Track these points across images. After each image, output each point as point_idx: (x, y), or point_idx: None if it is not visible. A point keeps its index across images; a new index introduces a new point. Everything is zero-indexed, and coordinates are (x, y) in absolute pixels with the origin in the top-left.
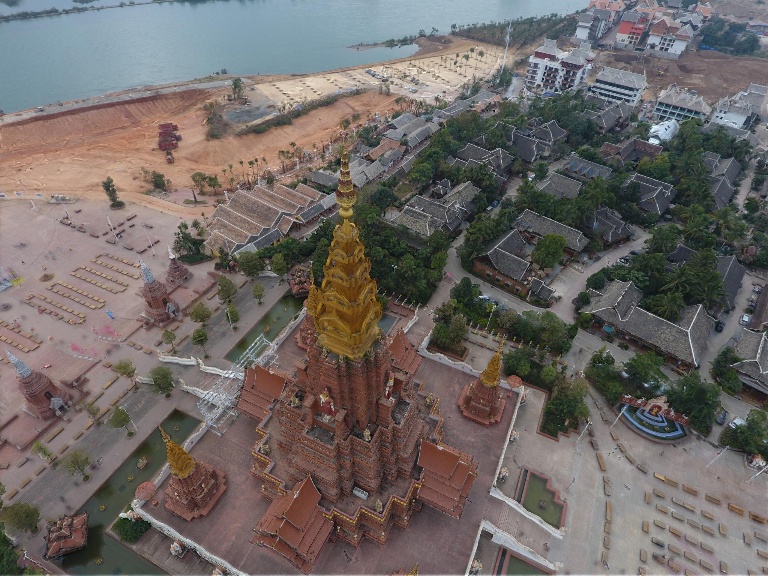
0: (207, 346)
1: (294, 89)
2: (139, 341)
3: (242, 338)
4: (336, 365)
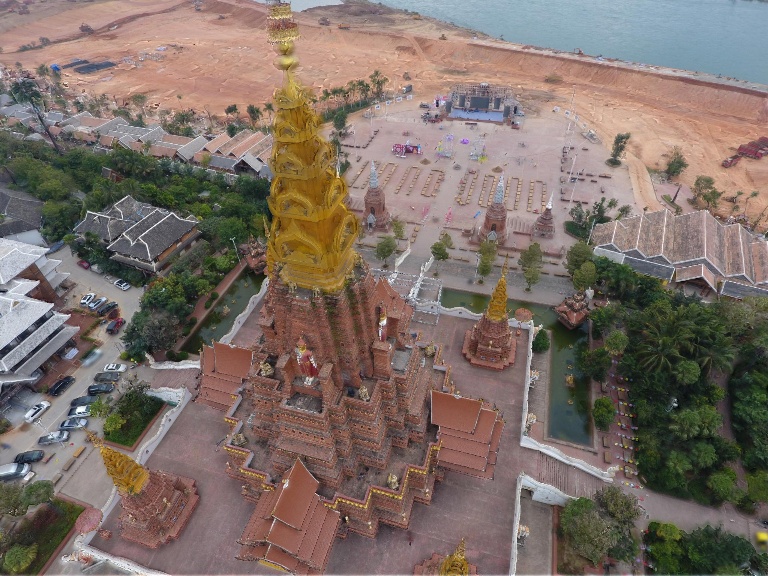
0: (453, 273)
1: None
2: None
3: (472, 292)
4: None
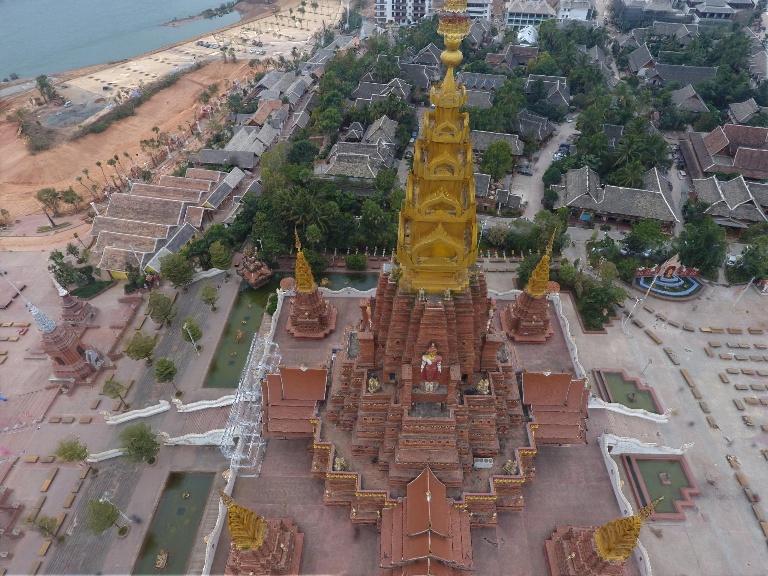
0: (171, 382)
1: (119, 77)
2: (65, 412)
3: (213, 356)
4: (443, 306)
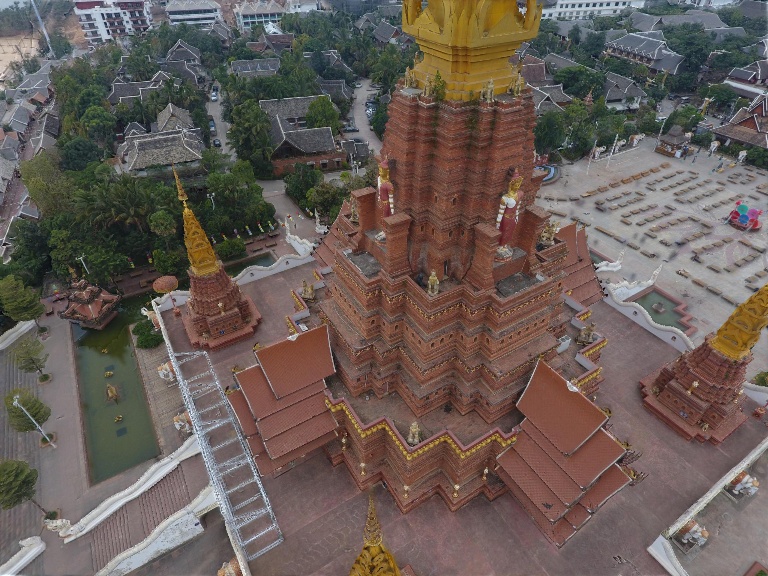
0: (19, 512)
1: None
2: None
3: (83, 436)
4: None
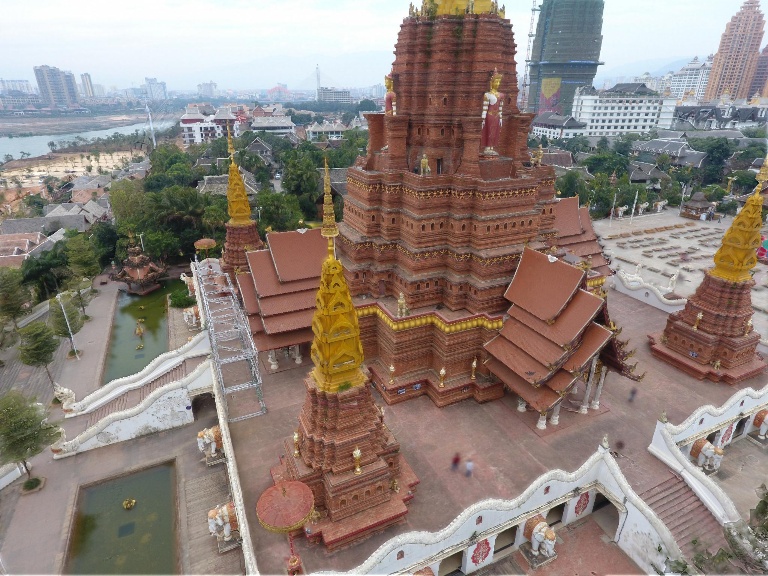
0: None
1: None
2: None
3: (105, 355)
4: None
